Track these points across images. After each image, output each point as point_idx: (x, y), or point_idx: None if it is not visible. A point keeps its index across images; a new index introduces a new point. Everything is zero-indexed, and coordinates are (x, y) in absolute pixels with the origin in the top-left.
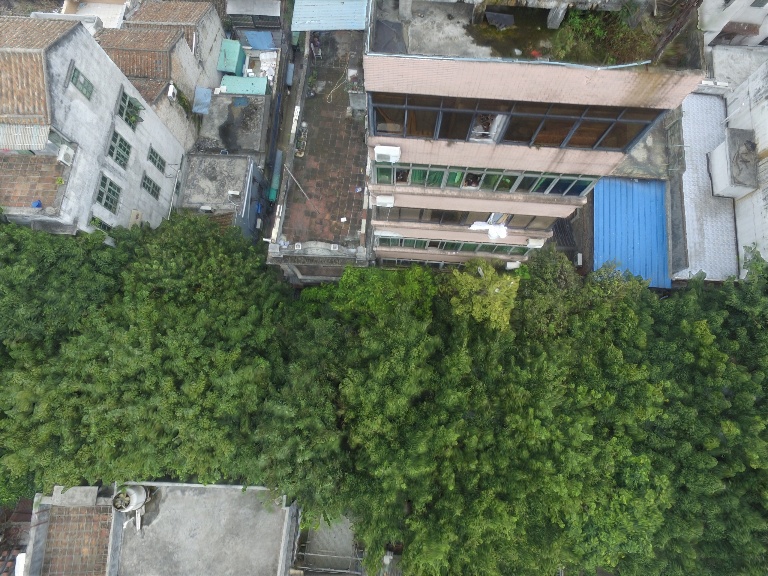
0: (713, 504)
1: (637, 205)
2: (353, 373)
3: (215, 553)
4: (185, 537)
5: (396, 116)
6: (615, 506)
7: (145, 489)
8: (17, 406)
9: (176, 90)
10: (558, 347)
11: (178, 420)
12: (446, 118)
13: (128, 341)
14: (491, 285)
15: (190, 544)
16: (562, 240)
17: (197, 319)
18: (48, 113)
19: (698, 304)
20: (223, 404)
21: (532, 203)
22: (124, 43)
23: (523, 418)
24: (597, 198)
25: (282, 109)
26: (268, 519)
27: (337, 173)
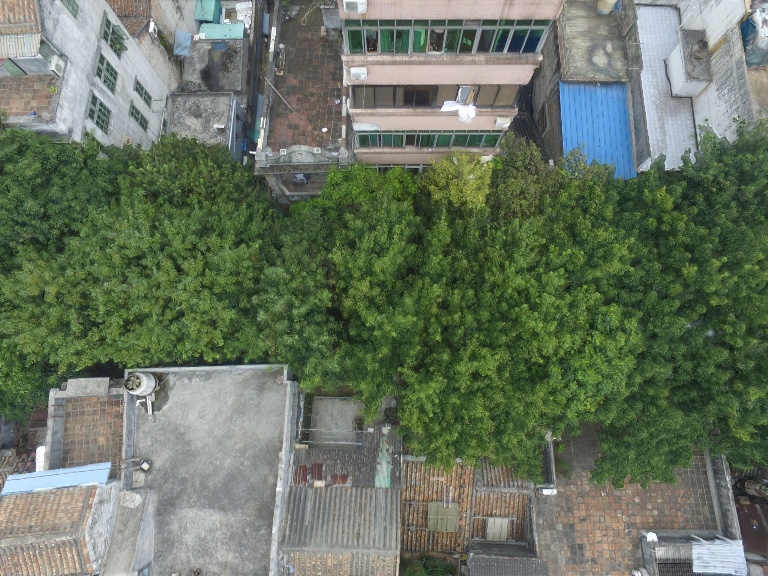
0: (680, 345)
1: (601, 107)
2: (341, 246)
3: (224, 431)
4: (195, 419)
5: None
6: (590, 349)
7: (154, 377)
8: (29, 289)
9: (157, 28)
10: None
11: (181, 291)
12: None
13: (129, 228)
14: (465, 165)
15: (200, 424)
16: None
17: (192, 216)
18: (38, 21)
19: None
20: (222, 279)
21: (493, 65)
22: None
23: (500, 273)
24: (563, 103)
25: (260, 56)
26: (271, 397)
27: (316, 88)
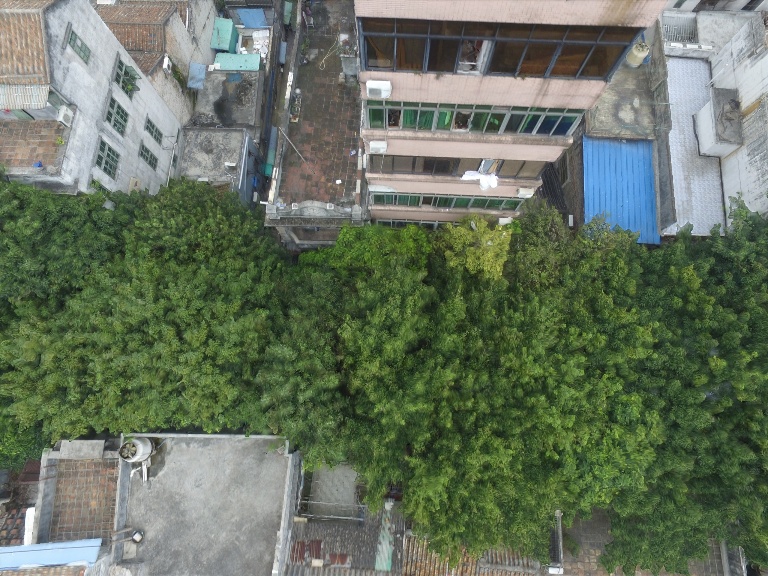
0: (702, 439)
1: (625, 165)
2: (351, 319)
3: (220, 502)
4: (191, 487)
5: (386, 47)
6: (608, 441)
7: (151, 441)
8: (24, 356)
9: (171, 63)
10: (550, 296)
11: (182, 365)
12: (434, 46)
13: (131, 293)
14: (483, 235)
15: (196, 494)
16: (553, 204)
17: (198, 275)
18: (47, 72)
19: (686, 255)
20: (225, 351)
21: (520, 145)
22: (118, 17)
23: (517, 358)
24: (586, 159)
25: (276, 86)
26: (271, 468)
27: (331, 137)
